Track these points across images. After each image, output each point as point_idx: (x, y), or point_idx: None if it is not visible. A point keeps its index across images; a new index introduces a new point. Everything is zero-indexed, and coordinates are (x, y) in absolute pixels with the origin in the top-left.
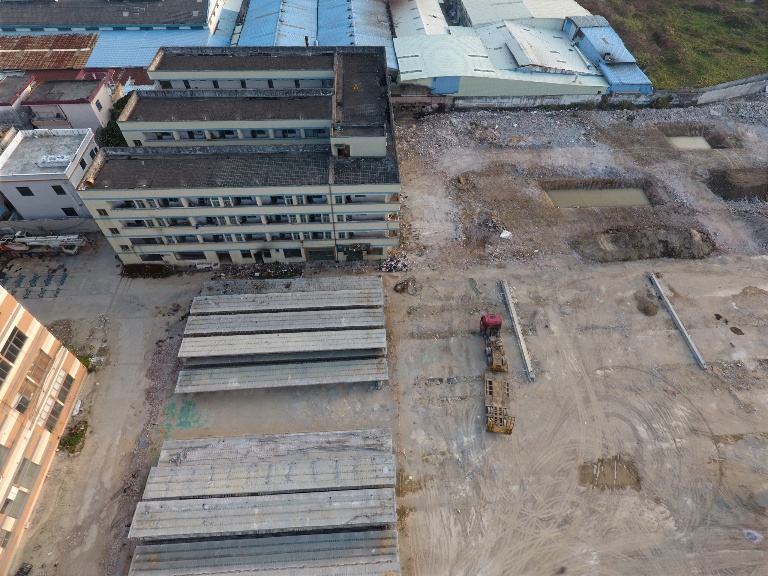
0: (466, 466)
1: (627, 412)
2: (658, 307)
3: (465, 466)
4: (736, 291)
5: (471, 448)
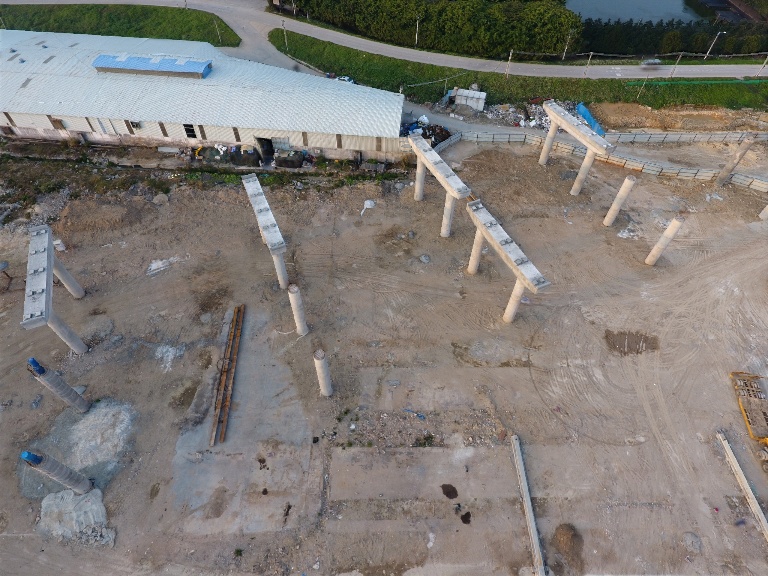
0: (760, 354)
1: (612, 393)
2: (551, 542)
3: (761, 354)
4: (413, 575)
5: (761, 368)
